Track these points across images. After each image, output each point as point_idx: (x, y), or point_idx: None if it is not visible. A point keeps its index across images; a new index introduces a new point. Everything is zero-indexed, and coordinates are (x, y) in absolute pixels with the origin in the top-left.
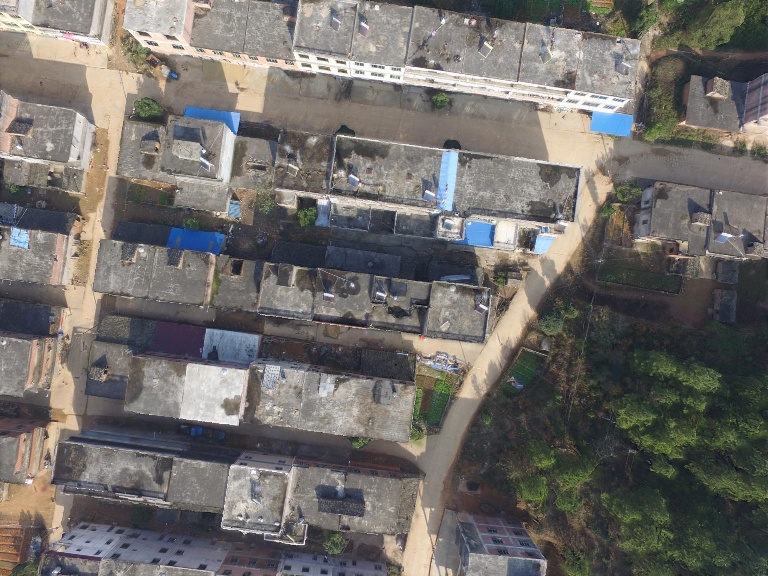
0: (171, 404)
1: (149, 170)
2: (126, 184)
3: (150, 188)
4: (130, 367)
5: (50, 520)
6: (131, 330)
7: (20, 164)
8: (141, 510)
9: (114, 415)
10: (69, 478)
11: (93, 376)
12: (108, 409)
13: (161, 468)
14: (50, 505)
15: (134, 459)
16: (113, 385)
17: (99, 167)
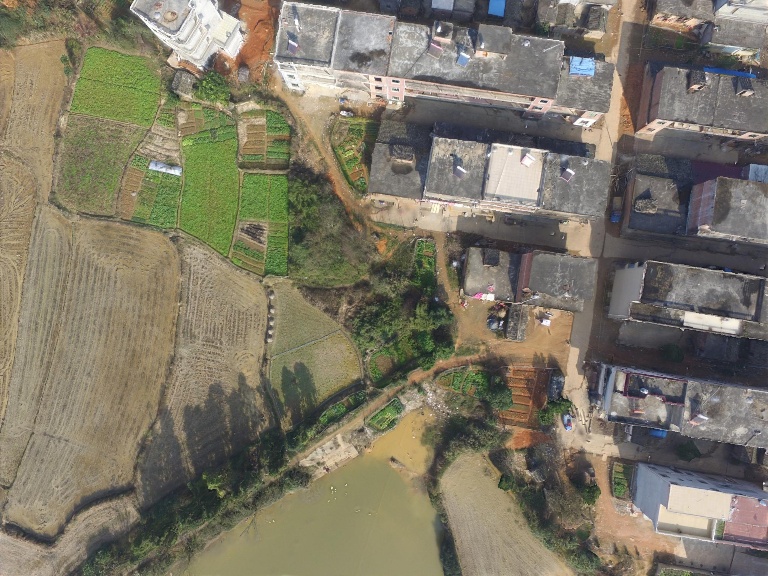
0: (759, 225)
1: (688, 7)
2: (642, 29)
3: (667, 32)
4: (717, 187)
5: (565, 363)
6: (668, 166)
7: (556, 3)
8: (678, 348)
9: (632, 257)
10: (655, 298)
11: (641, 208)
12: (626, 251)
13: (748, 290)
14: (565, 348)
15: (721, 280)
16: (657, 219)
17: (614, 12)
